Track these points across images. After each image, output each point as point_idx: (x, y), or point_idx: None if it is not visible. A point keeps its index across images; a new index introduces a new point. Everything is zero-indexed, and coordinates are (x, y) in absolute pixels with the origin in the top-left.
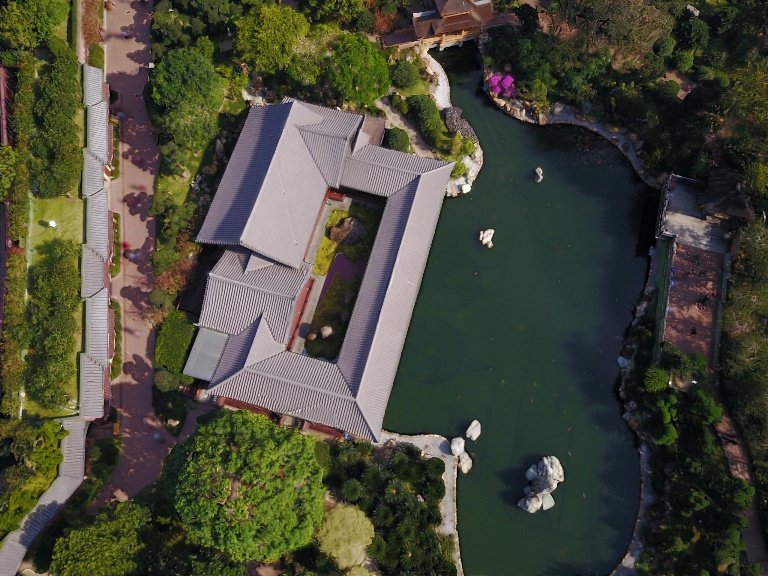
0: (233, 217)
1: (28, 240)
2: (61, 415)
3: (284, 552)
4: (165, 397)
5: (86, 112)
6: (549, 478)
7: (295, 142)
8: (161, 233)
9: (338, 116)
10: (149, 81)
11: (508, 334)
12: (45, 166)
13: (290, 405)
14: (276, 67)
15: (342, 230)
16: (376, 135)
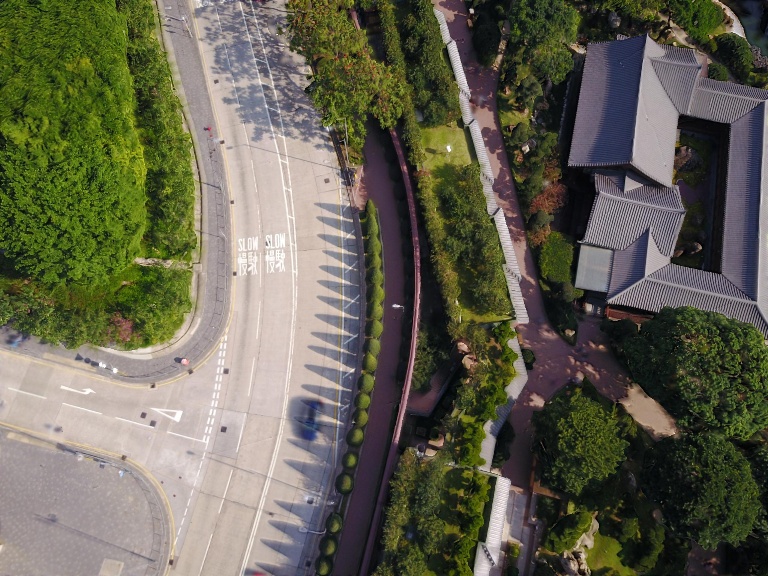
0: (606, 141)
1: (423, 165)
2: (498, 320)
3: (755, 431)
4: (566, 308)
5: (446, 50)
6: None
7: (648, 73)
8: (514, 163)
9: (673, 50)
10: (479, 24)
11: None
12: (429, 97)
13: None
14: (620, 4)
15: (680, 158)
16: (702, 69)
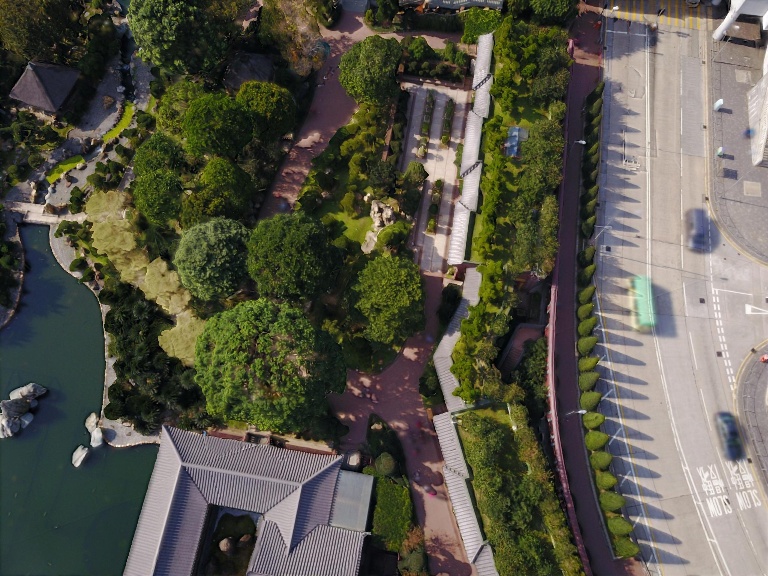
0: None
1: None
2: None
3: None
4: (385, 449)
5: None
6: (5, 414)
7: None
8: None
9: None
10: None
11: (31, 573)
12: None
13: (254, 453)
14: None
15: None
16: None
